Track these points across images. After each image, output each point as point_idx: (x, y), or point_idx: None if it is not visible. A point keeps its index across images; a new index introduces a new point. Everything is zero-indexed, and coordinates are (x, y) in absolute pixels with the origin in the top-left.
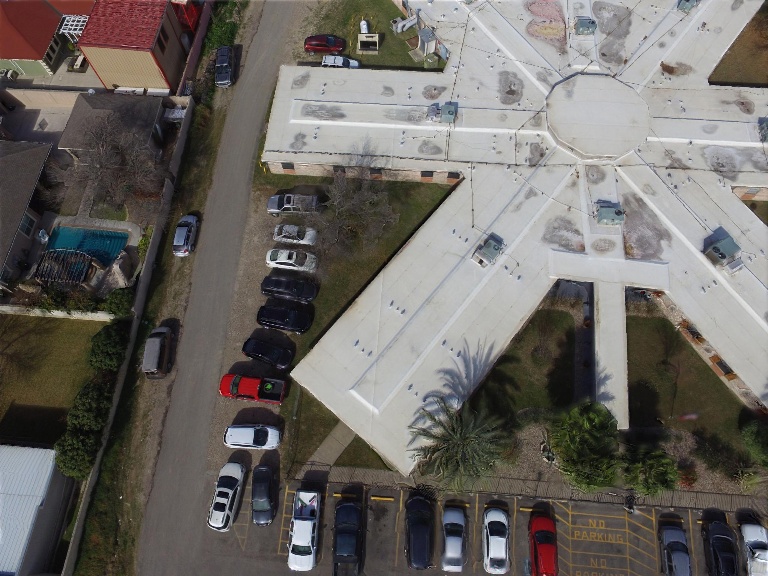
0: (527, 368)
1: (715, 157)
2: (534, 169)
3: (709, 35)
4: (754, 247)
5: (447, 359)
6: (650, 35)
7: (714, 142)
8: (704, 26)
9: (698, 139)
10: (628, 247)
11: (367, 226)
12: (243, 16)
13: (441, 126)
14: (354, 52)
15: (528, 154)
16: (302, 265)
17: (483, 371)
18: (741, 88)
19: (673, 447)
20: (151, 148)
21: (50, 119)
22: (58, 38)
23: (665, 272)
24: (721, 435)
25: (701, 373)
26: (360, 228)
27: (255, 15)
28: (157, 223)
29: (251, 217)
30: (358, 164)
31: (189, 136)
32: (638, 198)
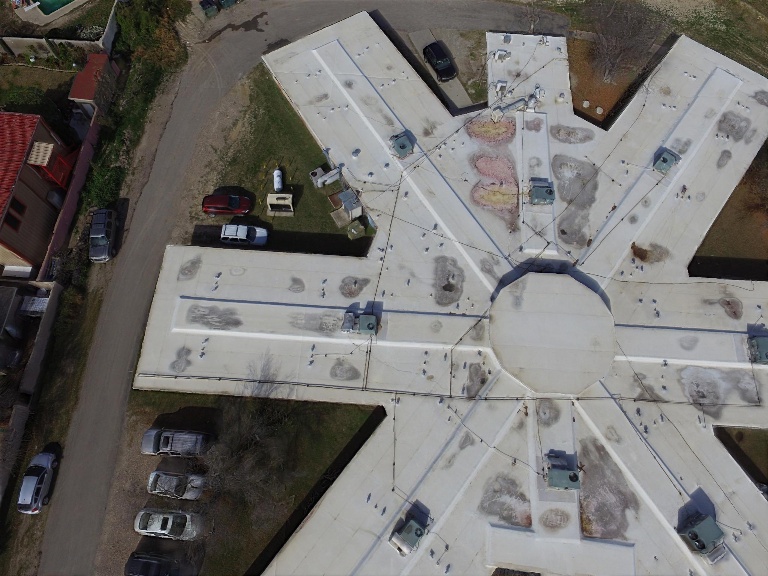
0: None
1: (694, 383)
2: (473, 403)
3: (690, 204)
4: (739, 518)
5: None
6: (620, 205)
7: (693, 362)
8: (684, 192)
9: (674, 358)
10: (585, 520)
11: (254, 506)
12: (133, 157)
13: (360, 339)
14: (264, 213)
15: (466, 380)
16: (179, 535)
17: None
18: (727, 281)
19: None
20: (0, 356)
21: None
22: None
23: (630, 559)
24: None
25: None
26: None
27: (147, 156)
28: None
29: (123, 455)
30: (254, 394)
31: (53, 334)
32: (599, 445)
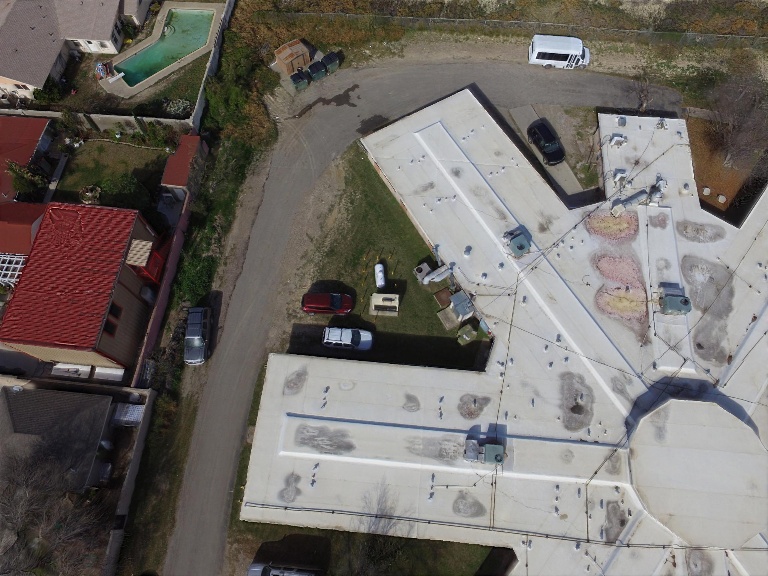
0: None
1: None
2: (613, 549)
3: None
4: None
5: None
6: (761, 316)
7: None
8: None
9: None
10: None
11: None
12: (224, 245)
13: (484, 469)
14: (366, 311)
15: (604, 521)
16: None
17: None
18: None
19: None
20: (95, 472)
21: None
22: None
23: None
24: None
25: None
26: None
27: (240, 244)
28: None
29: None
30: (371, 531)
31: (147, 445)
32: None
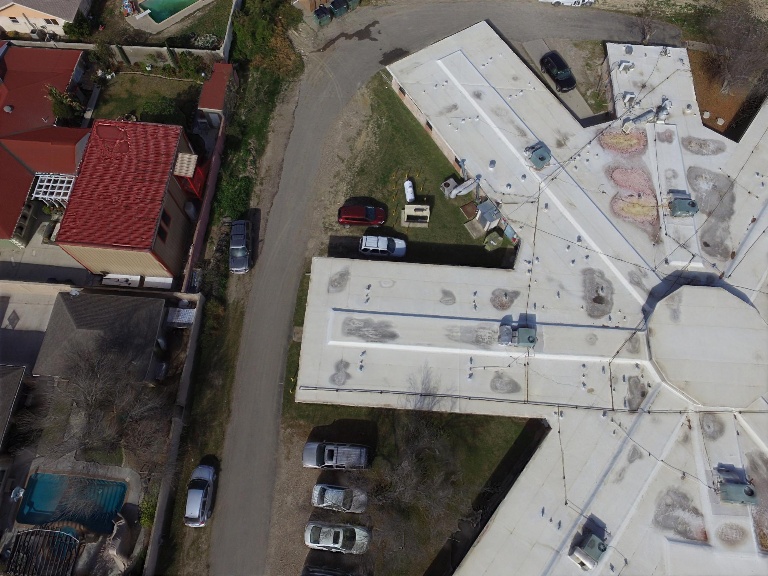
0: None
1: None
2: (636, 416)
3: None
4: None
5: None
6: (759, 217)
7: None
8: None
9: None
10: (759, 534)
11: (438, 520)
12: (259, 167)
13: (517, 352)
14: (398, 224)
15: (626, 393)
16: (350, 548)
17: None
18: None
19: None
20: (152, 368)
21: (22, 312)
22: (30, 201)
23: None
24: None
25: None
26: (426, 509)
27: (274, 166)
28: (163, 485)
29: (281, 467)
30: (417, 407)
31: (199, 345)
32: (765, 459)
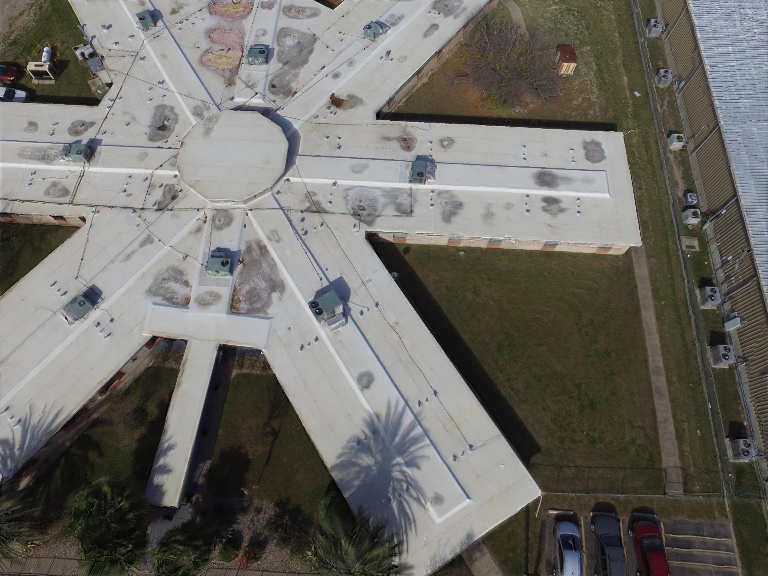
0: (116, 433)
1: (358, 199)
2: (160, 213)
3: (392, 65)
4: (370, 299)
5: (4, 429)
6: (328, 65)
7: (359, 183)
8: (388, 55)
9: (343, 180)
10: (235, 300)
11: None
12: None
13: (74, 166)
14: (30, 81)
15: (159, 197)
16: None
17: (38, 442)
18: (408, 123)
19: (249, 520)
20: None
21: None
22: None
23: (265, 328)
24: (304, 506)
25: (302, 436)
26: None
27: None
28: None
29: None
30: None
31: None
32: (262, 245)
